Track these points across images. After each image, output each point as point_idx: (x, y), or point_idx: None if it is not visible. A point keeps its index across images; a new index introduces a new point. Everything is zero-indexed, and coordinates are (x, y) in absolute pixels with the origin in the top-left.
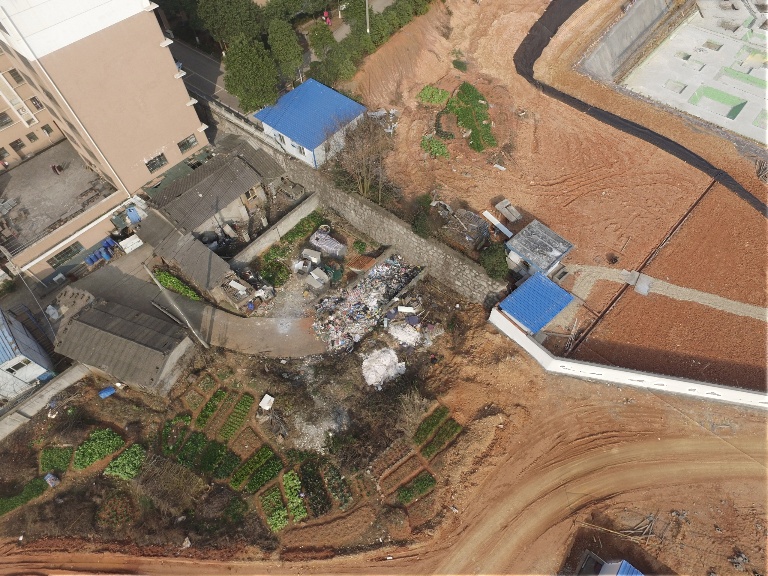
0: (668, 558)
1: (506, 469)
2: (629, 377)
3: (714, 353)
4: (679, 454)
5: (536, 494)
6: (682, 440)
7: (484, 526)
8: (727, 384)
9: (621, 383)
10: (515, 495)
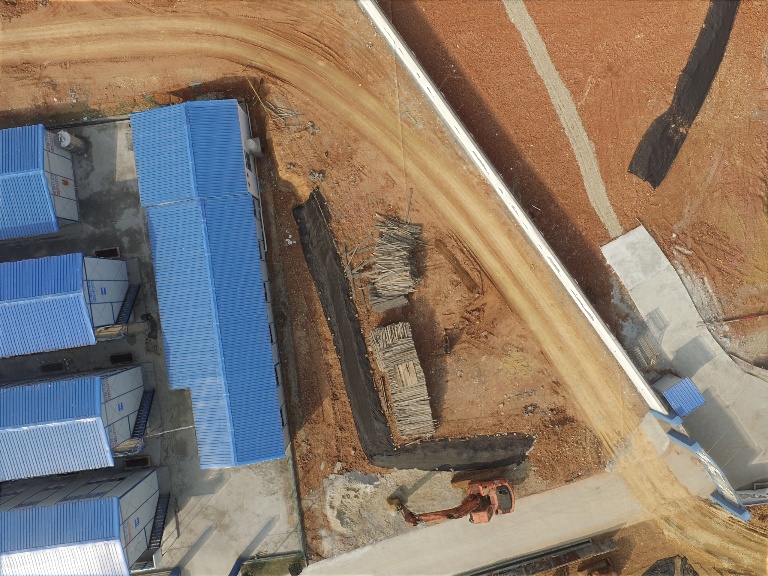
0: (277, 136)
1: (235, 5)
2: (382, 22)
3: (475, 75)
4: (359, 103)
5: (238, 36)
6: (373, 99)
7: (186, 21)
8: (453, 100)
9: (381, 30)
10: (224, 24)
